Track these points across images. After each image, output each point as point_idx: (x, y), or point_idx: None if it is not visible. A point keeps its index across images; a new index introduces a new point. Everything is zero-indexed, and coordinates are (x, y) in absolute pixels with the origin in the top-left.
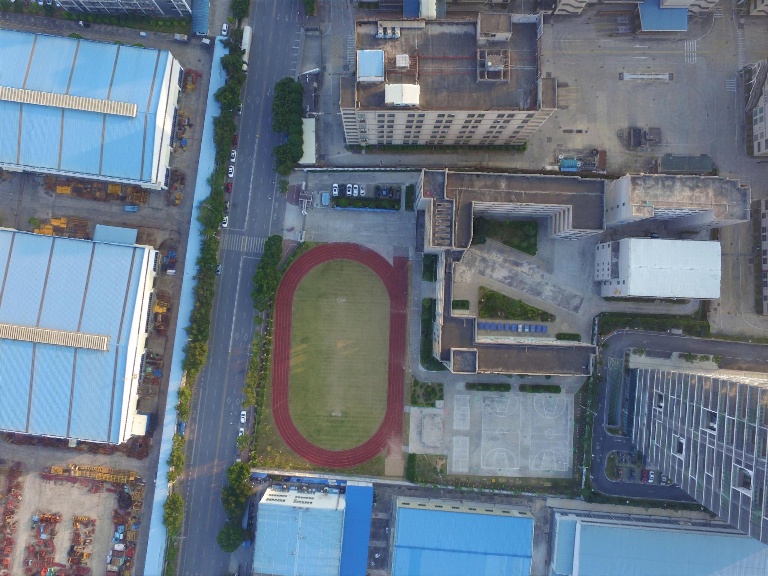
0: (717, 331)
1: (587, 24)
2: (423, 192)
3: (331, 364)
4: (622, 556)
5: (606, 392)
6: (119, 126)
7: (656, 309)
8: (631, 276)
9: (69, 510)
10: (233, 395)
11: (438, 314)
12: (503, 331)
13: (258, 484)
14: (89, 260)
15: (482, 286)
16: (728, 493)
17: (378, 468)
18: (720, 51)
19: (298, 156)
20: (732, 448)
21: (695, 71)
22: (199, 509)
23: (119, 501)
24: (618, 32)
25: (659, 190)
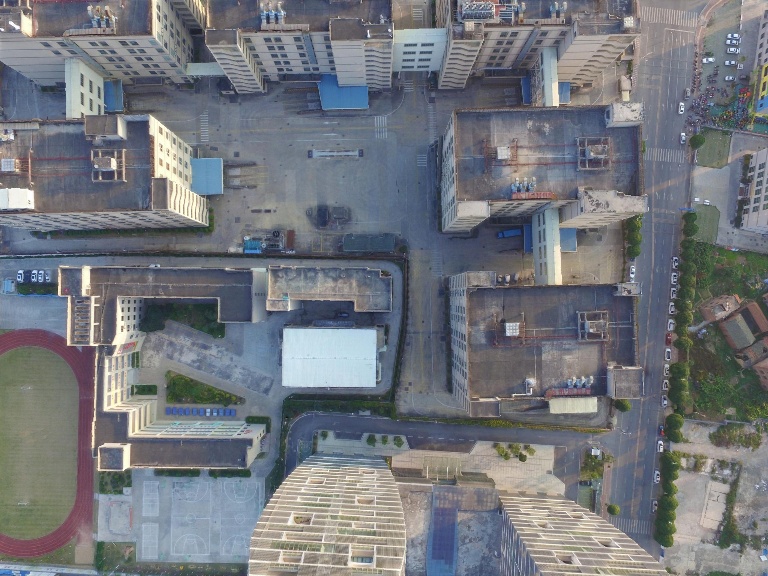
0: (408, 411)
1: (275, 102)
2: (61, 290)
3: (19, 452)
4: None
5: None
6: None
7: (347, 389)
8: (284, 367)
9: None
10: None
11: None
12: (191, 415)
13: None
14: None
15: (170, 370)
16: None
17: (68, 556)
18: (411, 126)
19: None
20: None
21: (385, 147)
22: None
23: None
24: (307, 109)
25: (301, 282)
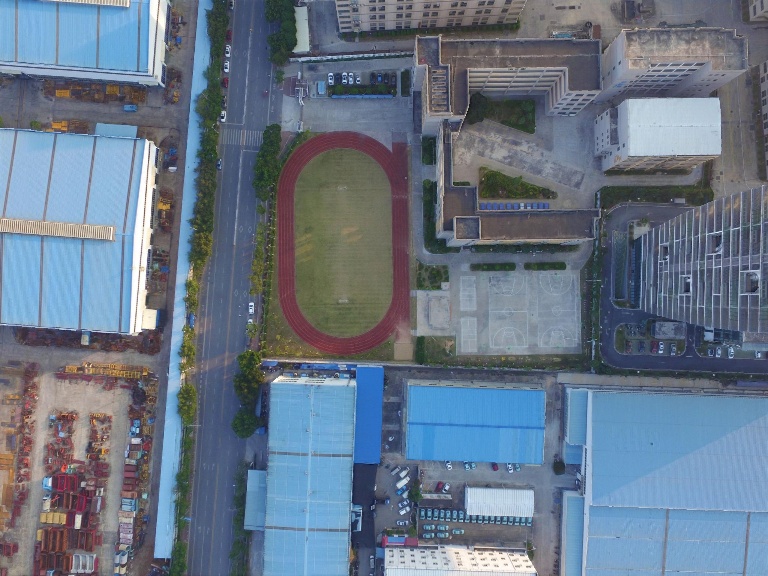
0: None
1: None
2: (418, 60)
3: (335, 252)
4: (635, 421)
5: (612, 266)
6: (113, 17)
7: (658, 181)
8: (631, 136)
9: (85, 408)
10: (240, 287)
11: (439, 191)
12: None
13: (269, 373)
14: (91, 154)
15: (482, 167)
16: (736, 302)
17: (387, 353)
18: None
19: (292, 43)
20: (738, 257)
21: None
22: (212, 401)
23: (133, 396)
24: None
25: (655, 45)
